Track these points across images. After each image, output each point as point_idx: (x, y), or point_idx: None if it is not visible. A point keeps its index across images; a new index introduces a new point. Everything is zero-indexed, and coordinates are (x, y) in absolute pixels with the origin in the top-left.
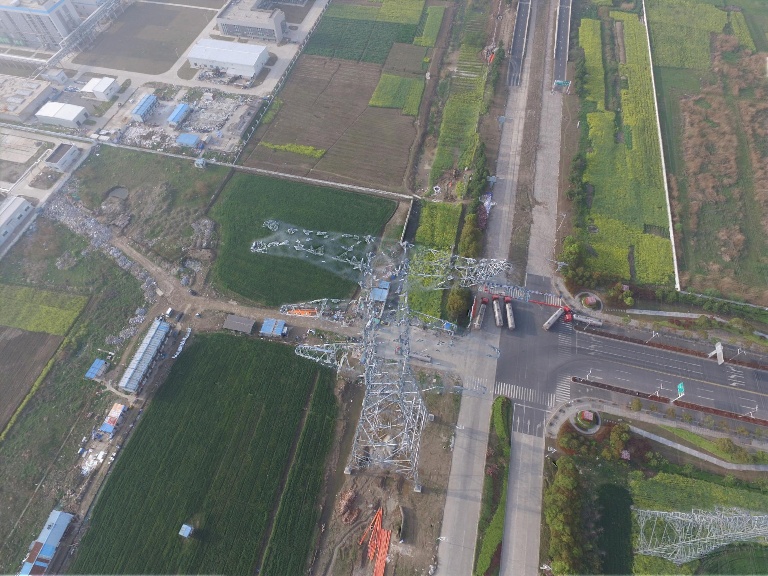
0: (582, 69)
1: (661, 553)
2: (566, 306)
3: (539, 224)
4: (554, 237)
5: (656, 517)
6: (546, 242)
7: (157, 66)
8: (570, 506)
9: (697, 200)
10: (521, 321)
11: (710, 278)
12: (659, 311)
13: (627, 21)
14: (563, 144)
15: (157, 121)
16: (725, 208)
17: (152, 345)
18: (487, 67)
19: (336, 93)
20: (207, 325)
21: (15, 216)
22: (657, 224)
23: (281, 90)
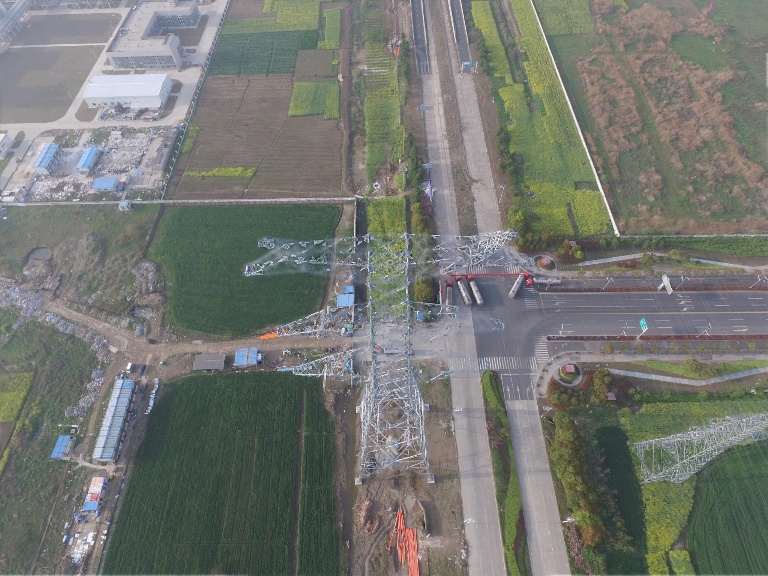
0: (484, 48)
1: (663, 477)
2: (524, 272)
3: (481, 200)
4: (497, 210)
5: (653, 445)
6: (491, 216)
7: (50, 113)
8: (576, 457)
9: (613, 151)
10: (487, 295)
11: (642, 219)
12: (606, 258)
13: None
14: (484, 121)
15: (65, 170)
16: (639, 154)
17: (120, 406)
18: (396, 60)
19: (252, 109)
20: (175, 371)
21: None
22: (585, 179)
23: (194, 116)
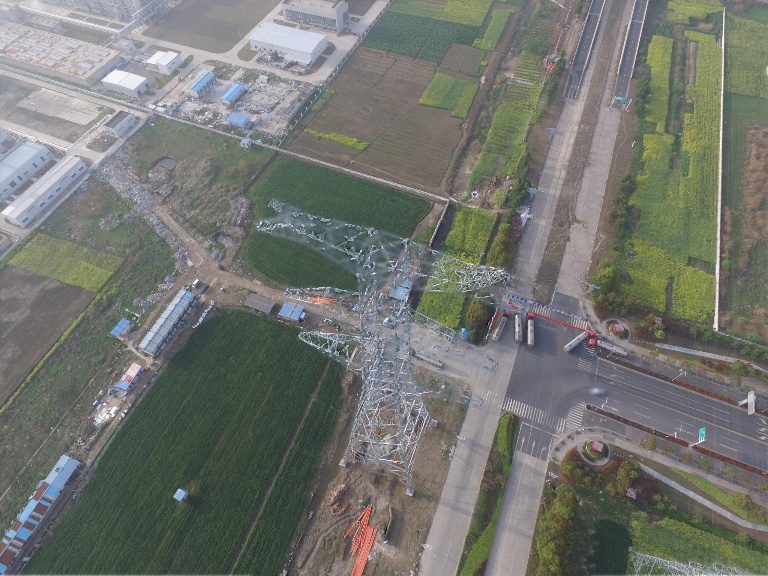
0: (646, 88)
1: None
2: (591, 330)
3: (575, 243)
4: (589, 258)
5: (653, 563)
6: (580, 262)
7: (220, 45)
8: (563, 536)
9: (751, 238)
10: (541, 339)
11: (753, 322)
12: (691, 349)
13: (703, 42)
14: (614, 163)
15: (212, 98)
16: None
17: (175, 312)
18: (545, 76)
19: (388, 88)
20: (229, 300)
21: (69, 174)
22: (703, 258)
23: (334, 80)
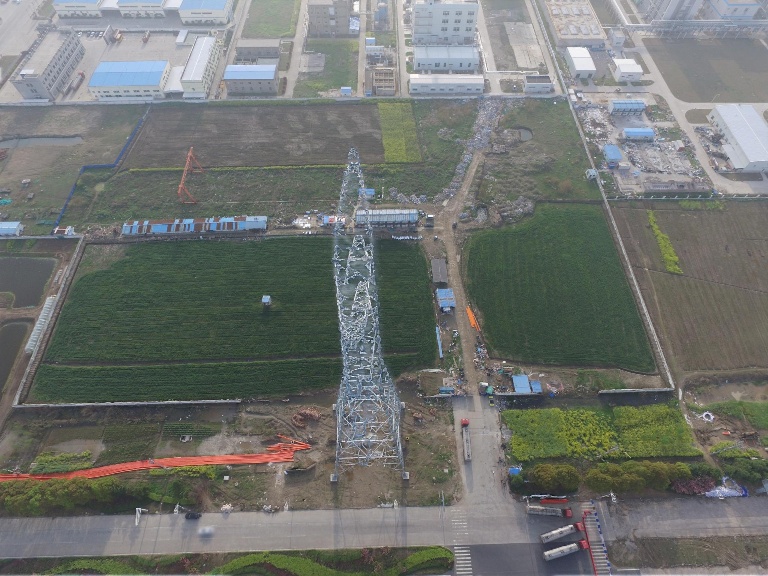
0: None
1: None
2: None
3: None
4: None
5: None
6: None
7: (686, 92)
8: None
9: None
10: (562, 570)
11: None
12: None
13: None
14: None
15: (619, 123)
16: None
17: (395, 217)
18: None
19: None
20: (429, 248)
21: (468, 86)
22: None
23: (739, 201)
